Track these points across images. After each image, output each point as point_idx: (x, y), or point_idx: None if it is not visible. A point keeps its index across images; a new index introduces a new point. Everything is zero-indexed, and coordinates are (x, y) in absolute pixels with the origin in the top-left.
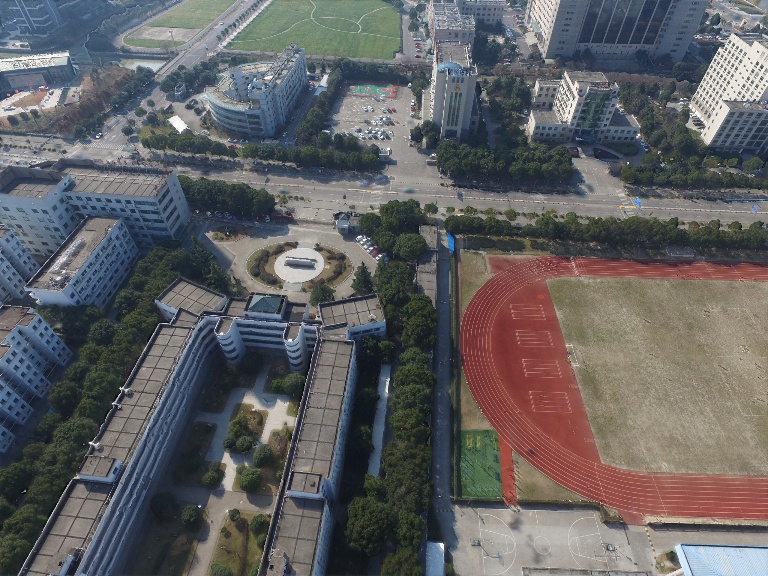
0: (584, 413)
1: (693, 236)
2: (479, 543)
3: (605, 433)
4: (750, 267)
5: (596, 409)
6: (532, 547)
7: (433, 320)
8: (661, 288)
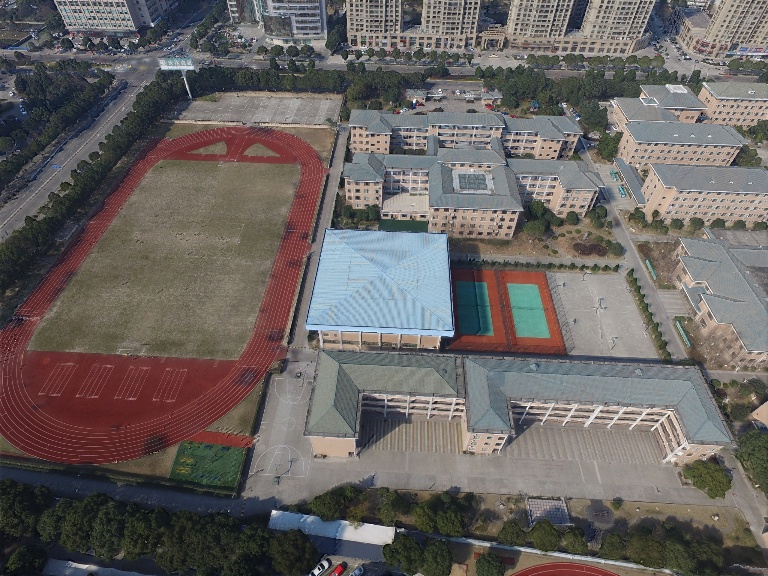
0: (191, 360)
1: (57, 215)
2: (277, 477)
3: (214, 350)
4: (111, 198)
5: (191, 350)
6: (288, 432)
7: (12, 486)
8: (97, 260)
